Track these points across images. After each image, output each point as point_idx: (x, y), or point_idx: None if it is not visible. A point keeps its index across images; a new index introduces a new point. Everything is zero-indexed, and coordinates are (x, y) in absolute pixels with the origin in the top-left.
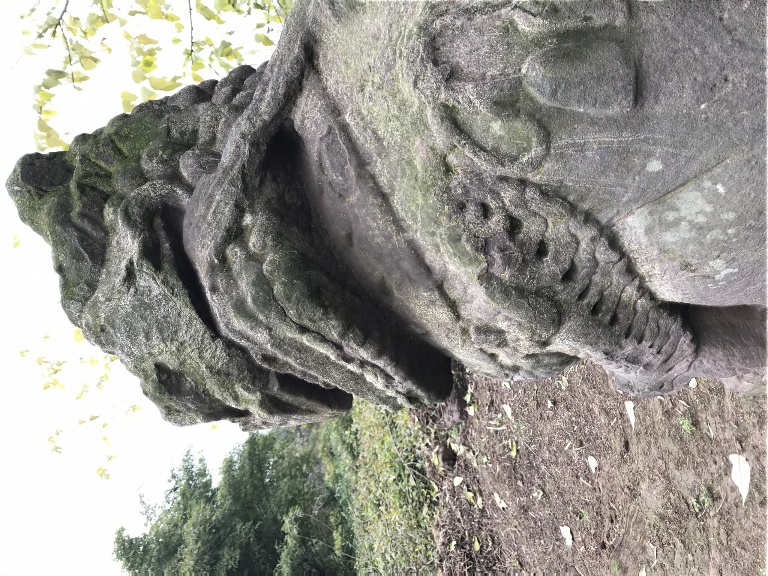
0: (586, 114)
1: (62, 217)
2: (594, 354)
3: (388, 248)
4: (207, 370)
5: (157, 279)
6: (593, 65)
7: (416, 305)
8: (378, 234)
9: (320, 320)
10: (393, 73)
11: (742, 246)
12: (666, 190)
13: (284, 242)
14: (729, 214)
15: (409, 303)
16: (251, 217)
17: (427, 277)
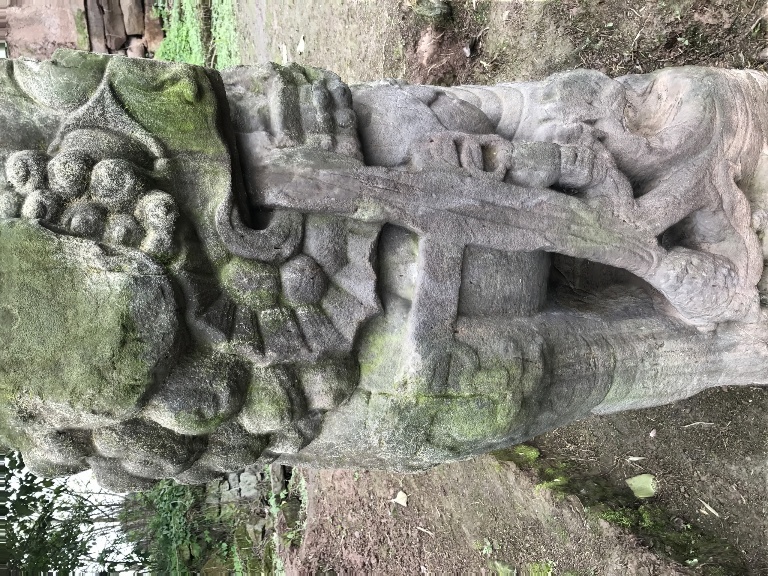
0: None
1: None
2: None
3: None
4: None
5: None
6: None
7: None
8: None
9: None
10: None
11: None
12: None
13: None
14: None
15: None
16: None
17: None
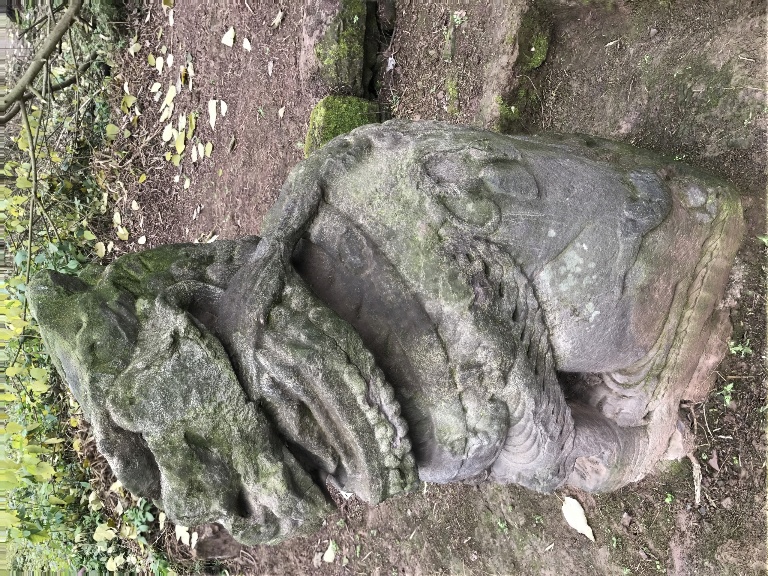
0: (516, 199)
1: (101, 303)
2: (528, 404)
3: (398, 302)
4: (238, 434)
5: (202, 344)
6: (516, 172)
7: (417, 353)
8: (390, 293)
9: (360, 352)
10: (397, 187)
11: (600, 290)
12: (558, 251)
13: (319, 304)
14: (592, 264)
15: (410, 353)
16: (290, 288)
17: (428, 322)
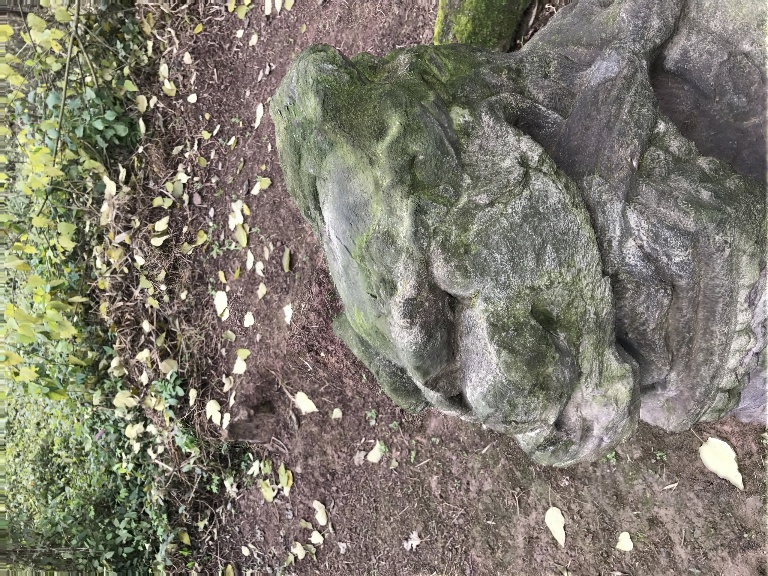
0: None
1: None
2: None
3: None
4: (594, 318)
5: (558, 182)
6: None
7: None
8: None
9: None
10: None
11: None
12: None
13: (701, 153)
14: None
15: None
16: (664, 125)
17: None
